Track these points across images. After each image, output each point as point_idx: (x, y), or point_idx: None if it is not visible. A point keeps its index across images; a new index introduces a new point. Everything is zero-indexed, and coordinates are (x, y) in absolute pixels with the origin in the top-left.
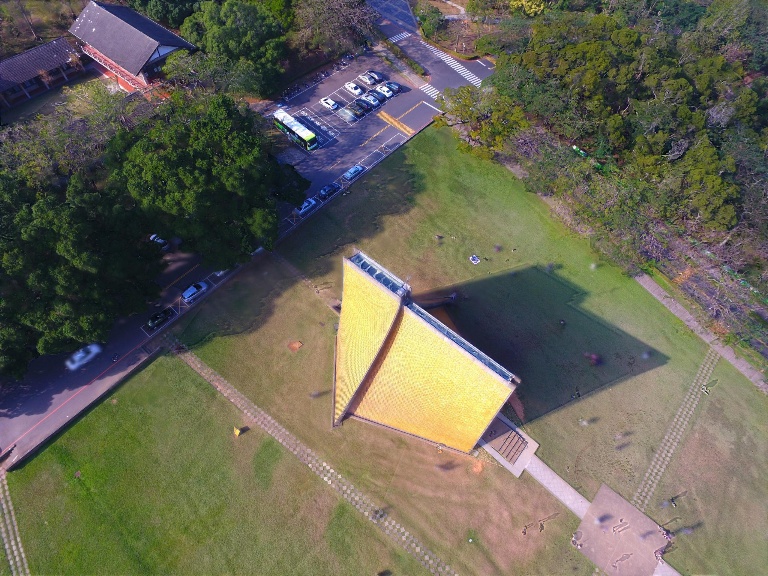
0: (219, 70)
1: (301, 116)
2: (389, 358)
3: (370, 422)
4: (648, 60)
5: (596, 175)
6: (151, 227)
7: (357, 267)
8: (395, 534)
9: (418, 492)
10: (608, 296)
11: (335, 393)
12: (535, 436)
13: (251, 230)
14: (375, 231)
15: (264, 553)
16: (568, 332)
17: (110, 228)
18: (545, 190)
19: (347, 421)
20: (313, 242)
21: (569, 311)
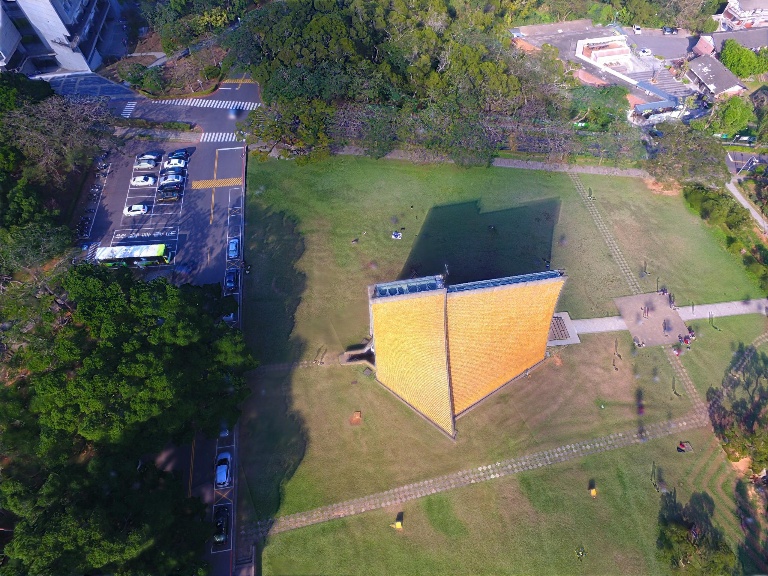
0: (20, 251)
1: (121, 241)
2: (452, 347)
3: (471, 408)
4: (363, 10)
5: (420, 111)
6: (137, 452)
7: (390, 297)
8: (568, 455)
9: (549, 415)
10: (493, 189)
11: (426, 417)
12: (560, 309)
13: (228, 364)
14: (306, 278)
15: (519, 572)
16: (501, 230)
17: (105, 492)
18: (390, 148)
19: (457, 425)
20: (270, 331)
21: (486, 217)
